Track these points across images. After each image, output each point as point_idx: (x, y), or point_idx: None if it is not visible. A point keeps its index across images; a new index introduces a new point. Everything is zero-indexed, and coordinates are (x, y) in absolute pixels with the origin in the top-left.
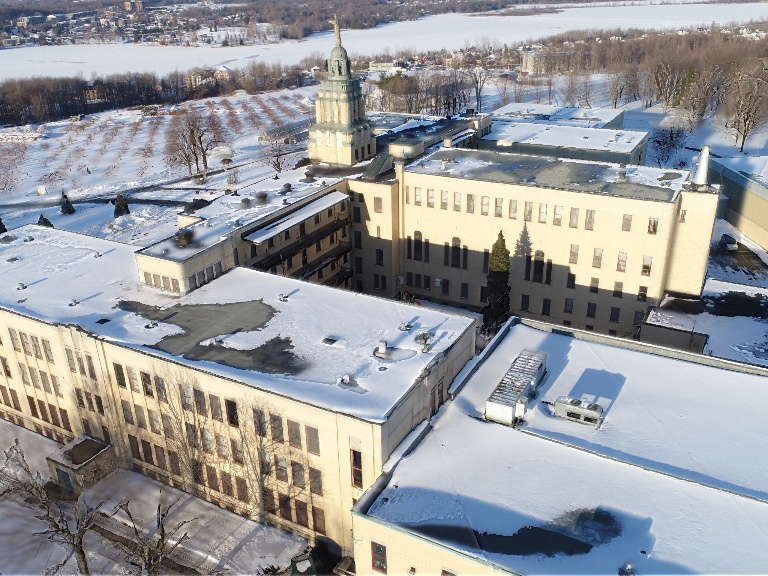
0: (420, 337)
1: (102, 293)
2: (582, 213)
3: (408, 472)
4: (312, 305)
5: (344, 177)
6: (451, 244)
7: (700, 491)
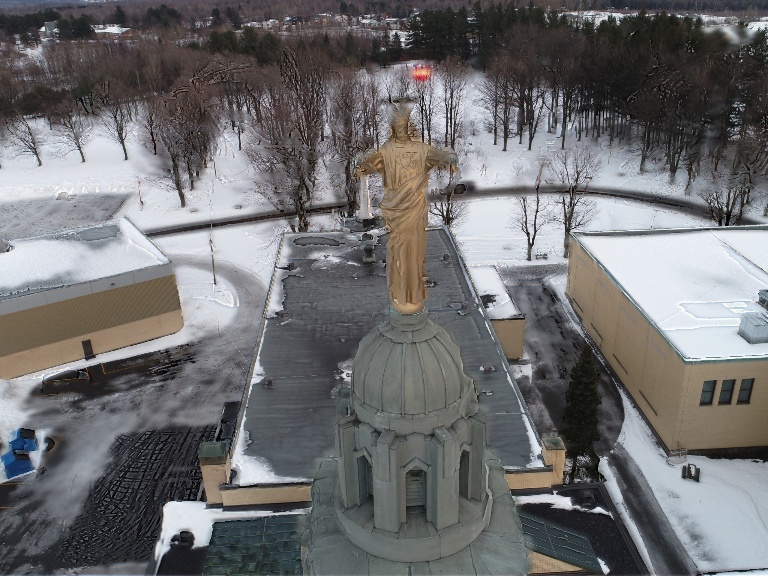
0: None
1: None
2: None
3: None
4: None
5: None
6: None
7: (766, 268)
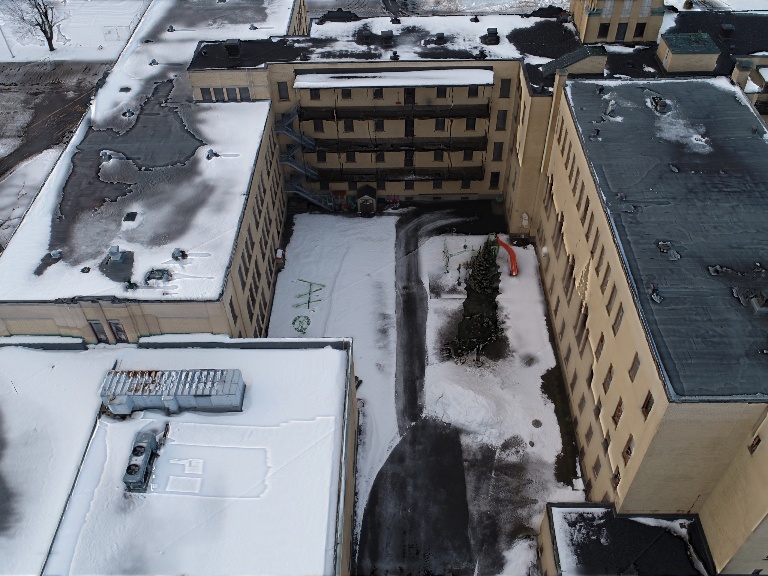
0: (150, 271)
1: (181, 65)
2: (617, 301)
3: (8, 357)
4: (207, 177)
5: (528, 55)
6: (559, 217)
7: None
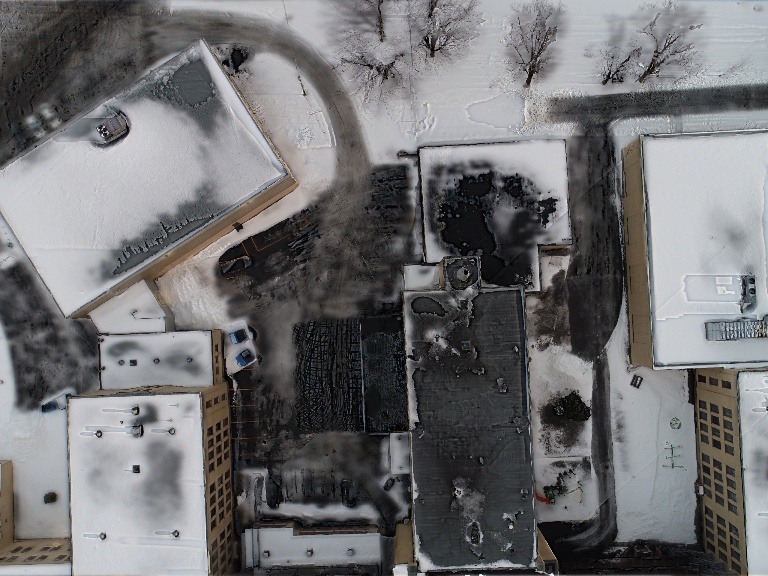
0: None
1: None
2: None
3: None
4: None
5: None
6: None
7: None
